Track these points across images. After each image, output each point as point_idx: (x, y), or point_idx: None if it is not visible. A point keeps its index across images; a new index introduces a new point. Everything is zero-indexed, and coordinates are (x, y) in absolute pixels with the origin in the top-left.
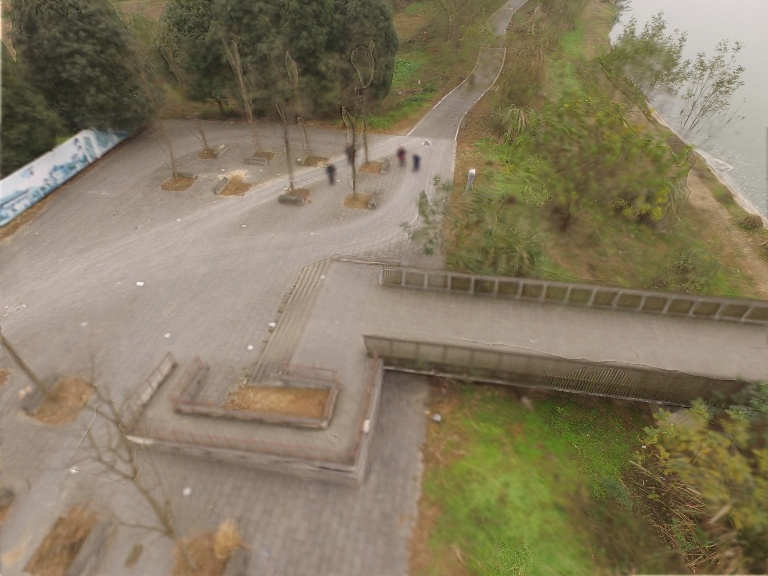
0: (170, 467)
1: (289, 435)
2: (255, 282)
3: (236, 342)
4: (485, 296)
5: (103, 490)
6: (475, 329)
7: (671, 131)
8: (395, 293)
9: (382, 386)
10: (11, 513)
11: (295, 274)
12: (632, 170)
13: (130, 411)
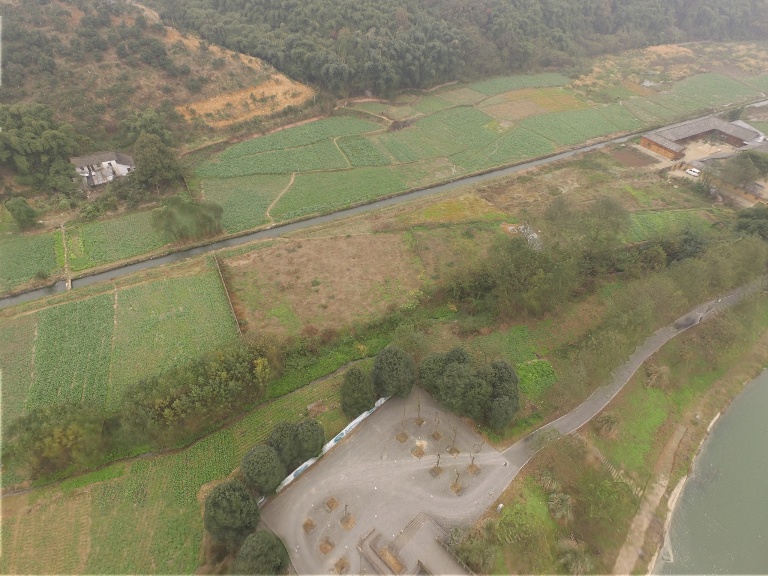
0: (364, 561)
1: (390, 572)
2: (405, 509)
3: (391, 531)
4: (461, 566)
5: (350, 557)
6: (451, 575)
7: (666, 514)
8: (438, 546)
9: (418, 573)
10: (333, 549)
11: (418, 513)
12: (534, 558)
13: (361, 539)
